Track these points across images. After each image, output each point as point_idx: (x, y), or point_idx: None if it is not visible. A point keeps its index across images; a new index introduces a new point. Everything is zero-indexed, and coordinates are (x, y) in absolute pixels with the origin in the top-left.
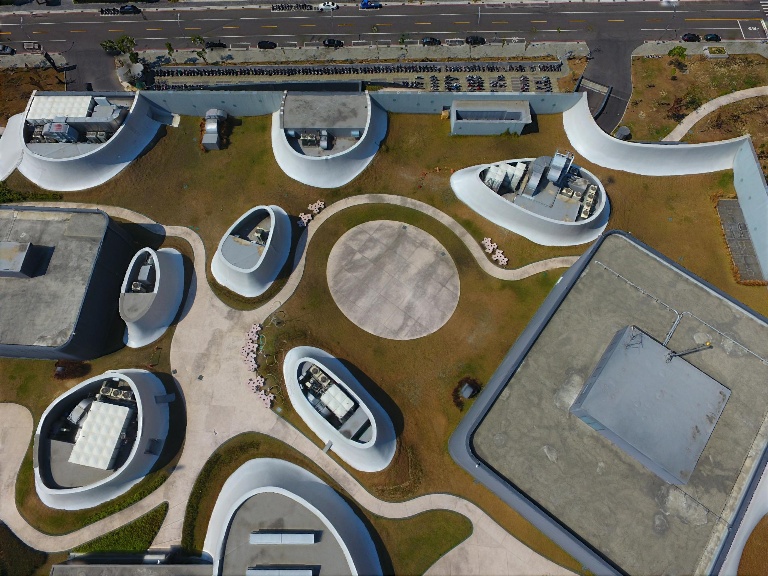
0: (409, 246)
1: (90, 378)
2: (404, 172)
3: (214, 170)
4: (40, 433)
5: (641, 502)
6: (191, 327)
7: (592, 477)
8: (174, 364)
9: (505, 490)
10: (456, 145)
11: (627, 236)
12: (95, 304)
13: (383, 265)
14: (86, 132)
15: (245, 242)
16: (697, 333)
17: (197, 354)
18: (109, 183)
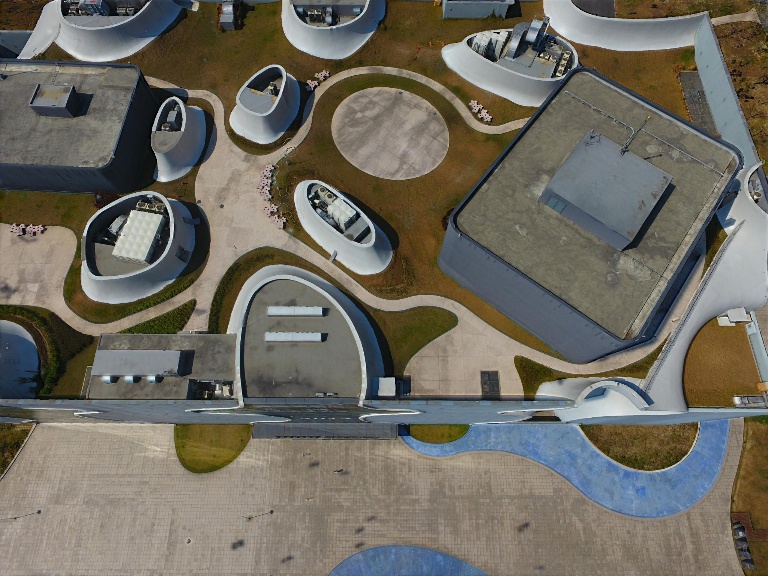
0: (404, 107)
1: (128, 195)
2: (400, 47)
3: (230, 47)
4: (86, 235)
5: (596, 264)
6: (213, 168)
7: (556, 247)
8: (198, 196)
9: (483, 261)
10: (447, 27)
11: (592, 71)
12: (130, 141)
13: (381, 122)
14: (116, 8)
15: (260, 93)
16: (649, 145)
17: (218, 188)
18: (137, 55)
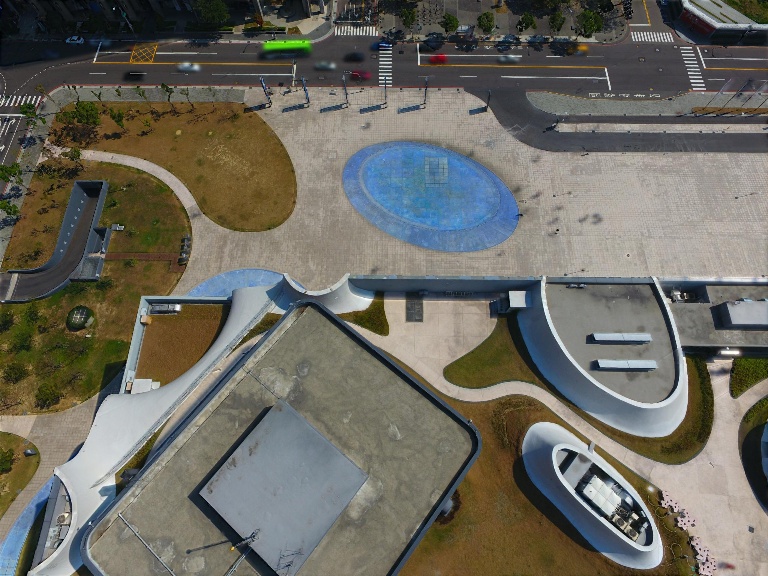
0: None
1: None
2: None
3: None
4: None
5: (316, 387)
6: None
7: (357, 409)
8: None
9: None
10: None
11: None
12: None
13: None
14: None
15: None
16: (198, 572)
17: (767, 561)
18: None
